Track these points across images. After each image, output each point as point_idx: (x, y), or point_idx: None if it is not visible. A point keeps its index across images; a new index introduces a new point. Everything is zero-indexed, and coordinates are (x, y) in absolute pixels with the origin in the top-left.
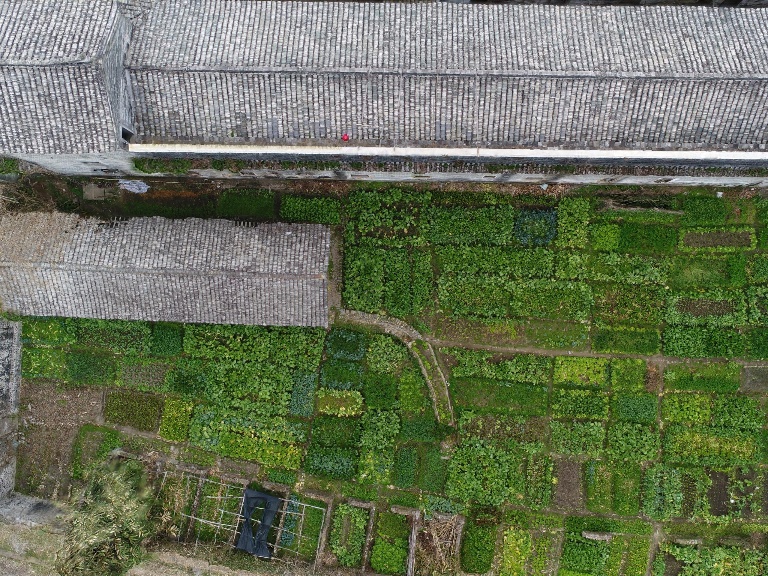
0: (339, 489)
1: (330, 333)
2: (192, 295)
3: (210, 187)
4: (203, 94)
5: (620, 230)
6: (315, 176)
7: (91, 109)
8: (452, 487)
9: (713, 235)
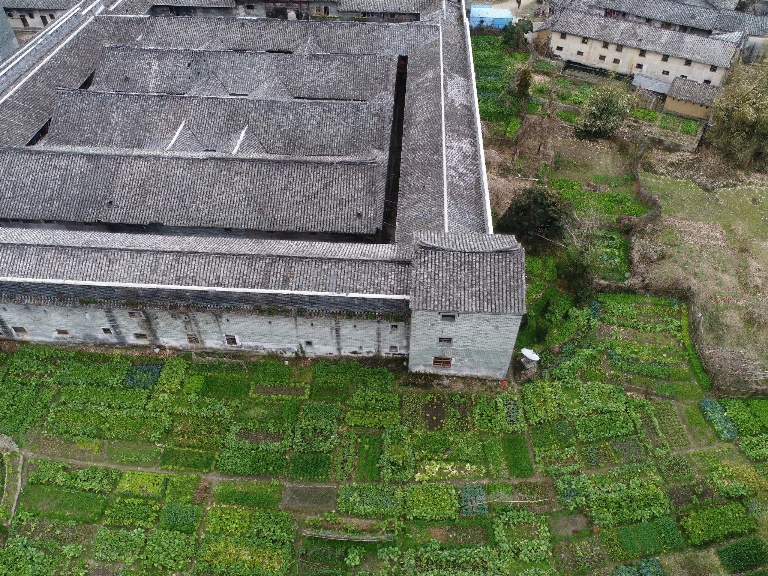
0: None
1: None
2: None
3: None
4: None
5: (204, 379)
6: None
7: None
8: None
9: (277, 388)
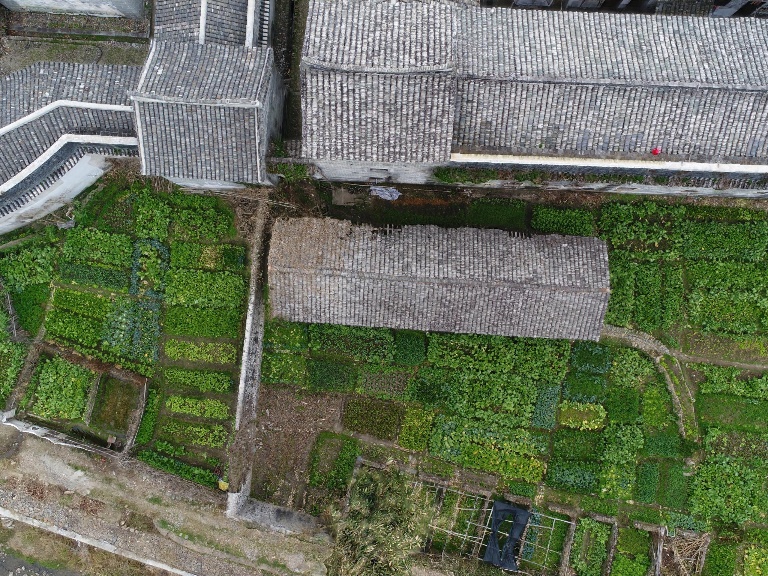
0: (578, 503)
1: (576, 346)
2: (468, 305)
3: (462, 196)
4: (521, 105)
5: None
6: (580, 188)
7: (435, 118)
8: (696, 504)
9: None
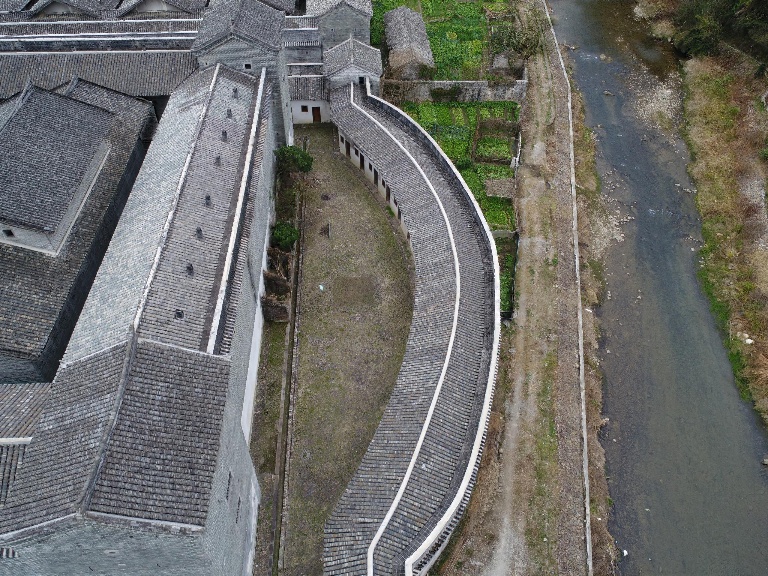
0: None
1: None
2: None
3: None
4: None
5: None
6: None
7: None
8: None
9: None
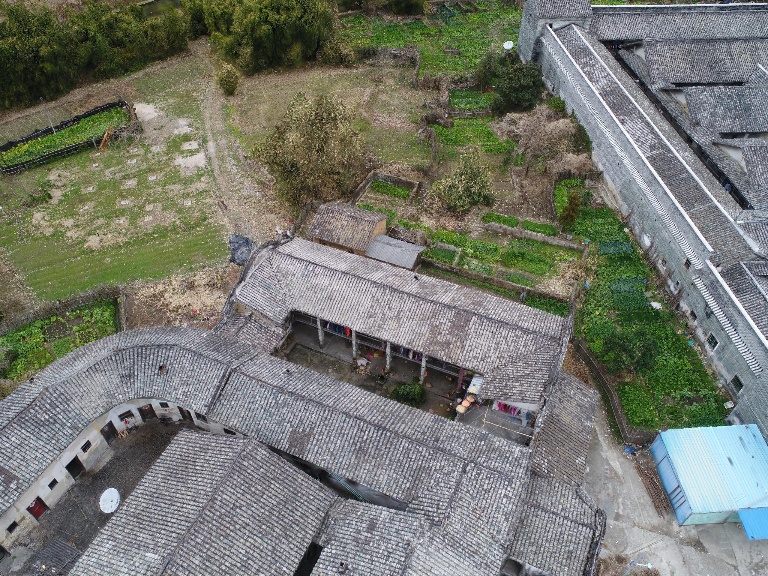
0: None
1: None
2: None
3: None
4: None
5: None
6: None
7: None
8: None
9: None
